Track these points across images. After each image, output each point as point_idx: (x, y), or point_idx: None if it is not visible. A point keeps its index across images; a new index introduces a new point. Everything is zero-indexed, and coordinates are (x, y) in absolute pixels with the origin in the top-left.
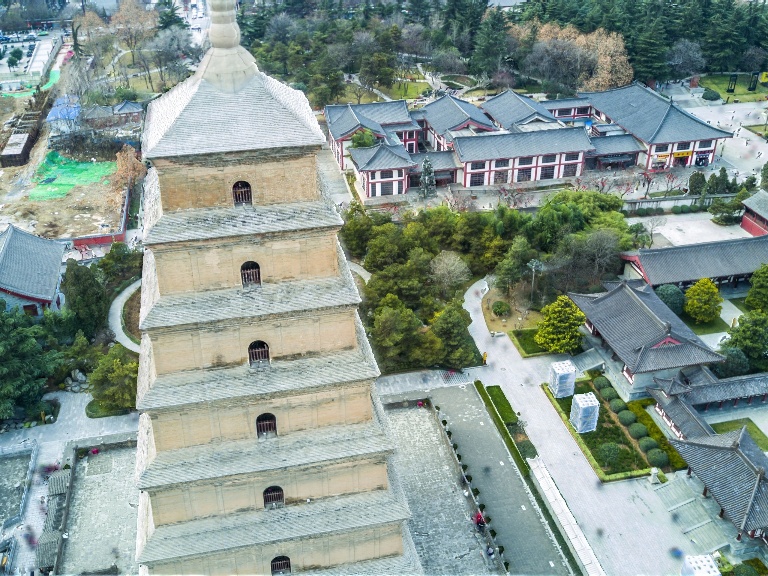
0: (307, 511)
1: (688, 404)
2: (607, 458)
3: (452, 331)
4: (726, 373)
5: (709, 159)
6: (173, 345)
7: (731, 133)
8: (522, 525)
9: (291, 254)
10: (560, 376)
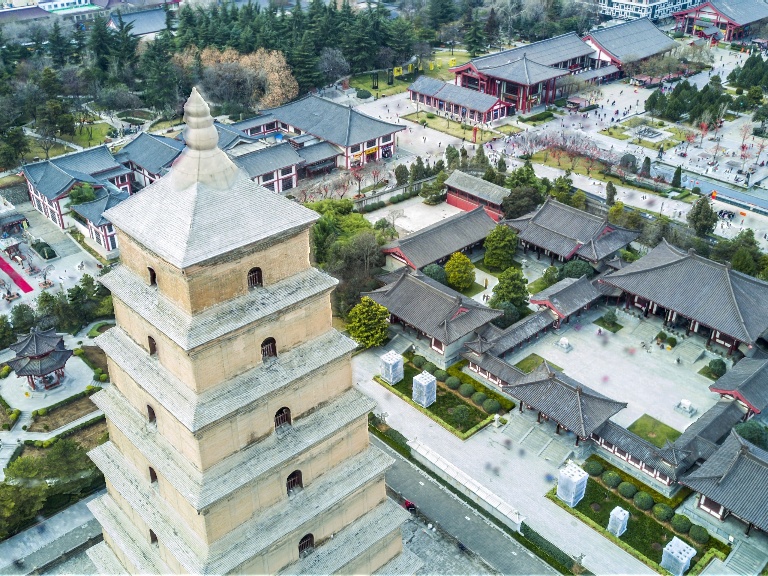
0: (333, 546)
1: (495, 356)
2: (462, 419)
3: None
4: (505, 324)
5: (392, 151)
6: (216, 437)
7: (404, 126)
8: (429, 498)
9: (299, 321)
10: (393, 366)
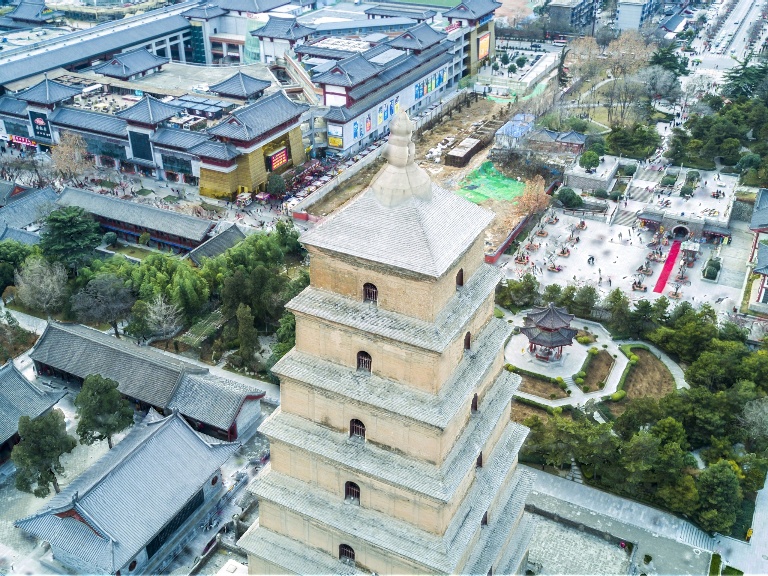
0: None
1: None
2: None
3: (715, 488)
4: None
5: None
6: (295, 393)
7: None
8: None
9: (398, 359)
10: None
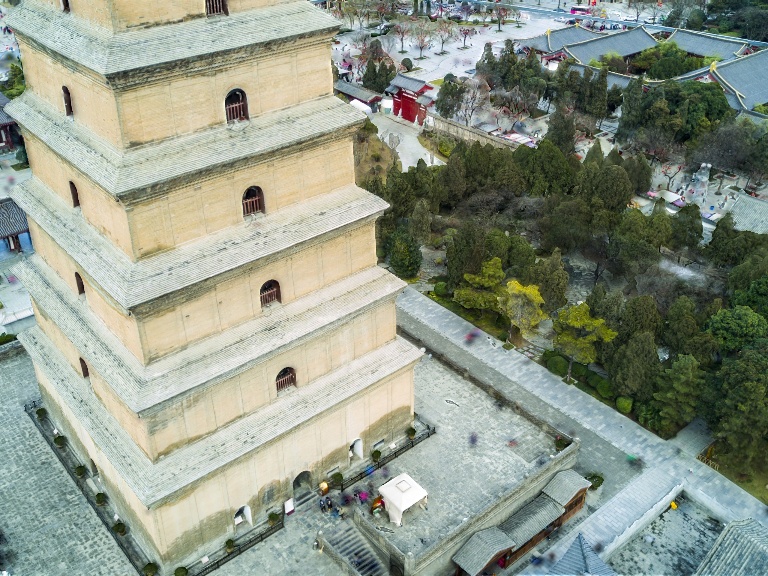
0: None
1: None
2: None
3: None
4: None
5: None
6: None
7: None
8: None
9: None
10: None
